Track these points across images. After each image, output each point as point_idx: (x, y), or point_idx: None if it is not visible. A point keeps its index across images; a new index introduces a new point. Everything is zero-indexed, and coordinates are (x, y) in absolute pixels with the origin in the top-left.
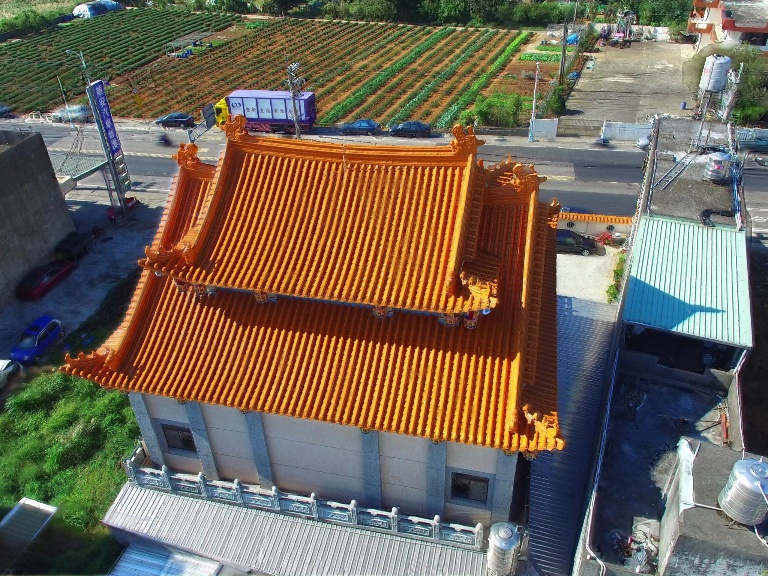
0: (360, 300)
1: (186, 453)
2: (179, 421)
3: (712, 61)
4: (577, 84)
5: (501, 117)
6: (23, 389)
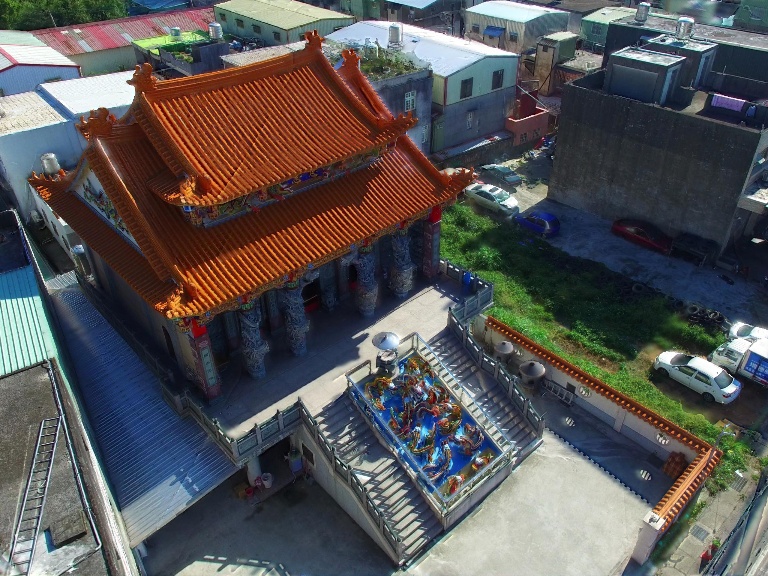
0: None
1: None
2: None
3: None
4: None
5: None
6: (483, 216)
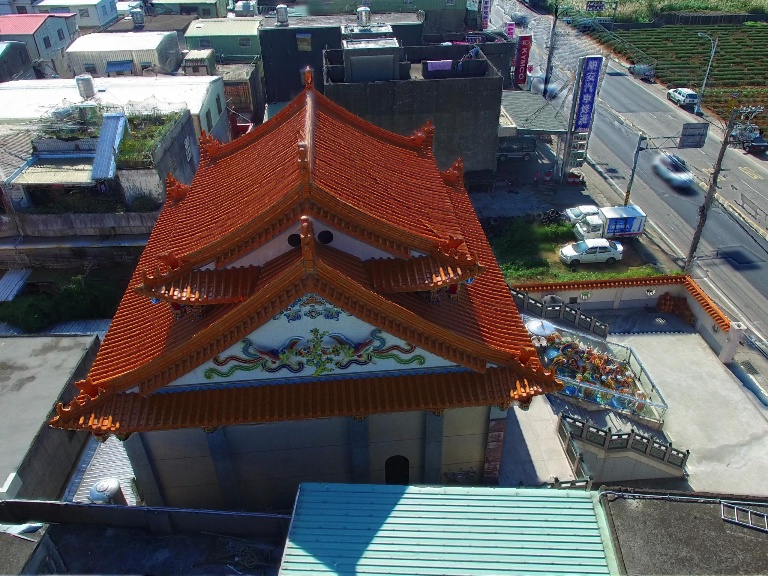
0: None
1: None
2: None
3: None
4: None
5: None
6: None
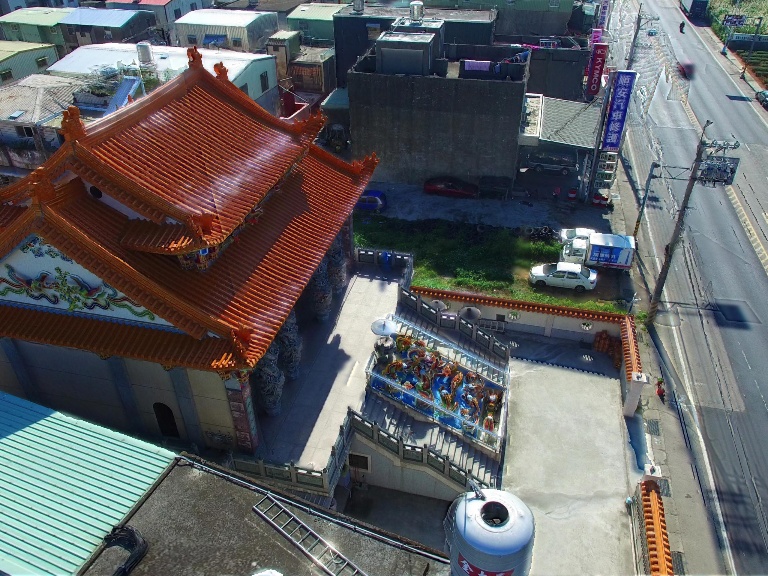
0: None
1: None
2: None
3: None
4: None
5: None
6: None
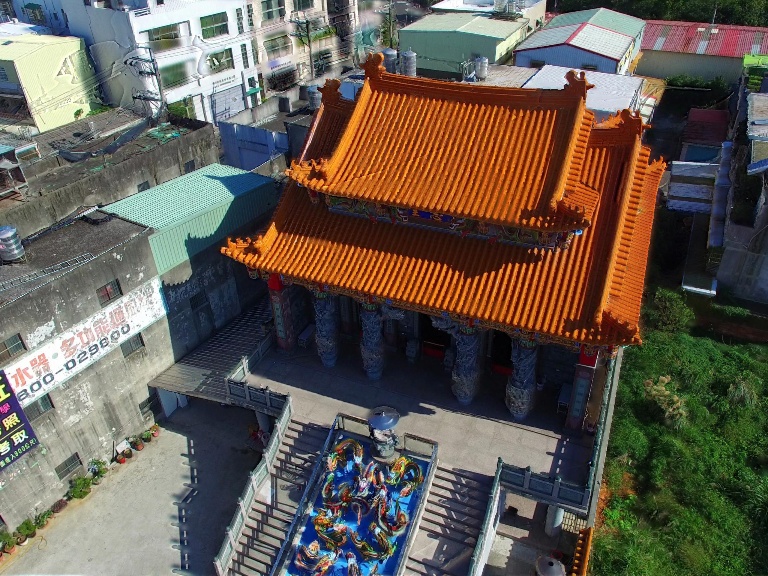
0: None
1: None
2: None
3: None
4: None
5: None
6: None
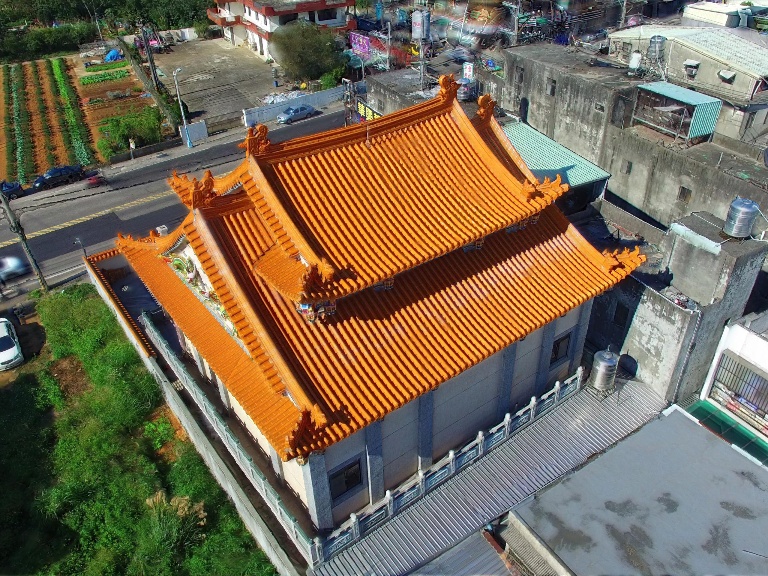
0: (485, 233)
1: (351, 493)
2: (352, 457)
3: (421, 15)
4: (170, 91)
5: (145, 135)
6: None
